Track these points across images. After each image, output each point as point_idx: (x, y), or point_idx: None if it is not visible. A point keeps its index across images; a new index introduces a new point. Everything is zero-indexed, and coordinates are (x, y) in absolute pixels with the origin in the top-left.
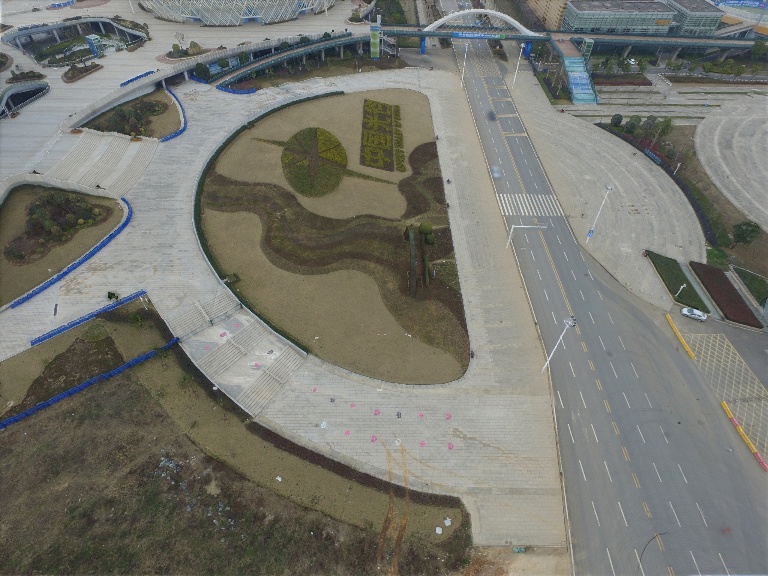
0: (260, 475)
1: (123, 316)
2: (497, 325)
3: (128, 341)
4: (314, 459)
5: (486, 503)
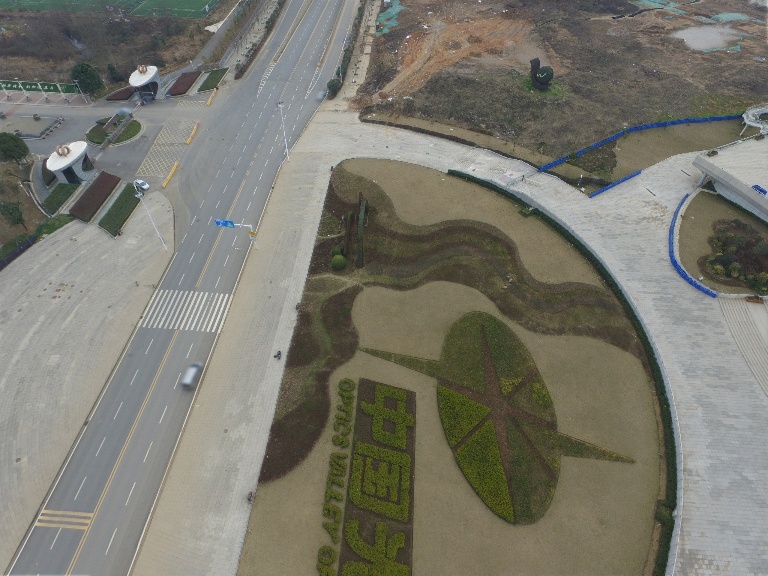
0: (461, 130)
1: (591, 179)
2: (305, 186)
3: (575, 170)
4: (435, 132)
5: (349, 121)
